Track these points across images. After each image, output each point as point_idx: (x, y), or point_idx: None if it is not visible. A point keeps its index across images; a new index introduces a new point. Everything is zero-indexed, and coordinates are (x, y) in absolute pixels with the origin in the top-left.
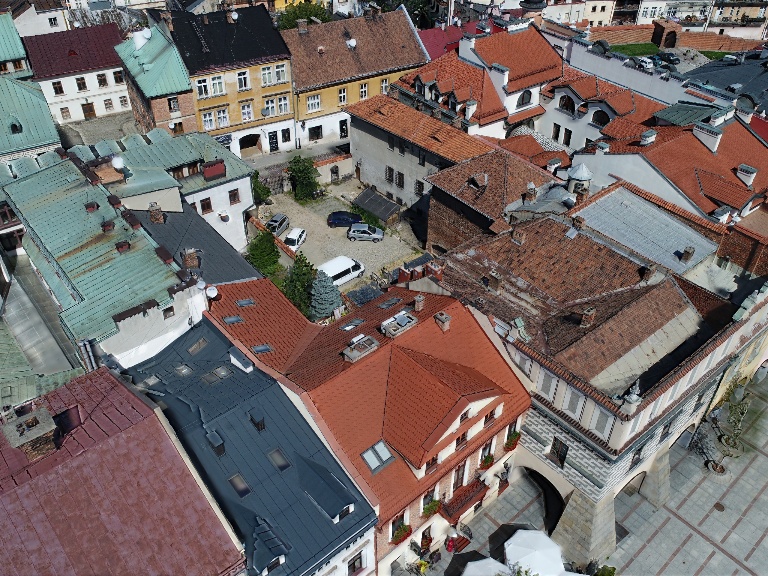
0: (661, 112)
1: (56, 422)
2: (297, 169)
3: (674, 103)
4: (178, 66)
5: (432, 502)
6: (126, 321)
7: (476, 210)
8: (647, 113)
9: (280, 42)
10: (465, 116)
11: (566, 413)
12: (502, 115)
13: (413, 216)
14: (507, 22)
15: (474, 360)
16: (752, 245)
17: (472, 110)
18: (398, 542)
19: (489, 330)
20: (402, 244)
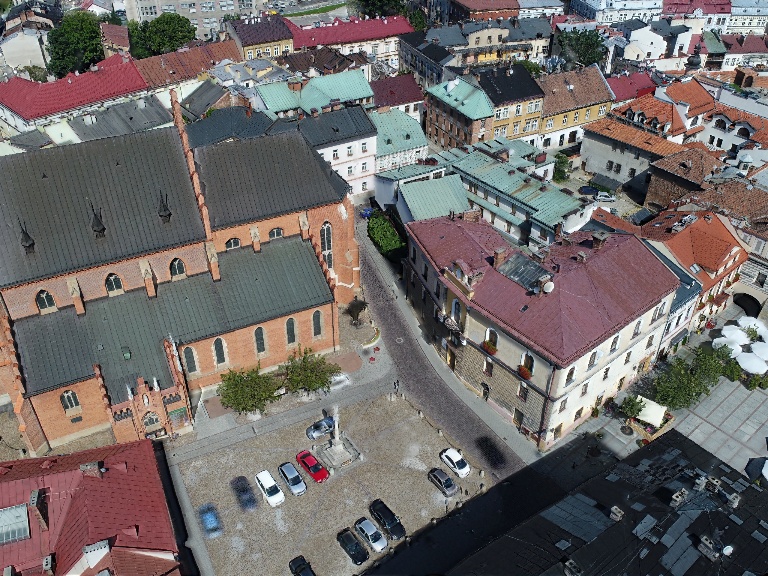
0: None
1: None
2: (561, 161)
3: None
4: (486, 102)
5: (711, 296)
6: (570, 217)
7: (687, 179)
8: None
9: (537, 87)
10: (663, 131)
11: (767, 258)
12: (684, 130)
13: (626, 190)
14: (681, 77)
15: (723, 237)
16: None
17: (668, 127)
18: (701, 308)
19: (728, 224)
20: (628, 203)
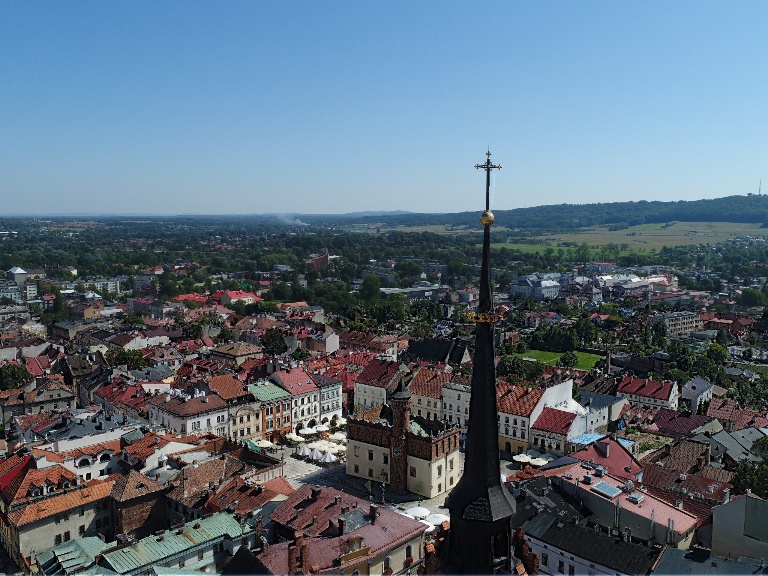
0: (130, 439)
1: (301, 506)
2: None
3: (120, 437)
4: None
5: None
6: None
7: (155, 491)
8: (117, 445)
9: None
10: None
11: None
12: None
13: None
14: (30, 448)
15: None
16: (214, 444)
17: None
18: None
19: None
20: None
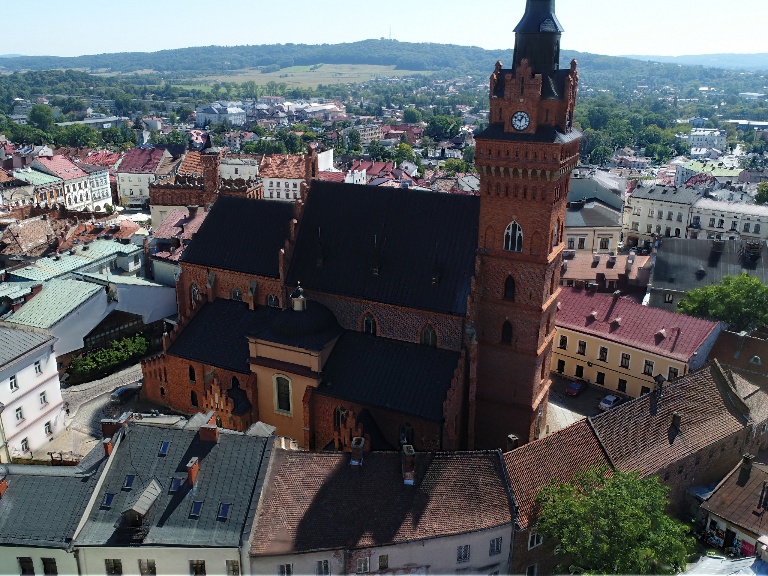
0: None
1: None
2: None
3: None
4: None
5: None
6: None
7: None
8: None
9: None
10: None
11: None
12: None
13: None
14: None
15: None
16: None
17: None
18: None
19: None
20: None
